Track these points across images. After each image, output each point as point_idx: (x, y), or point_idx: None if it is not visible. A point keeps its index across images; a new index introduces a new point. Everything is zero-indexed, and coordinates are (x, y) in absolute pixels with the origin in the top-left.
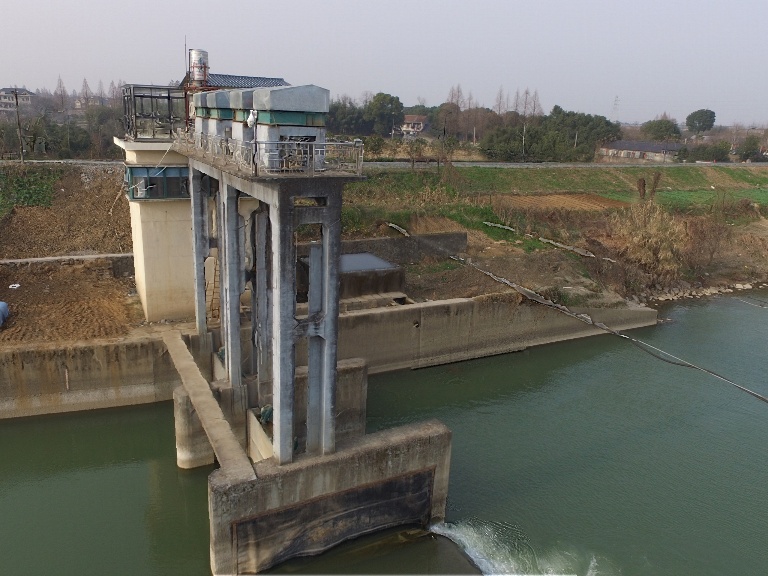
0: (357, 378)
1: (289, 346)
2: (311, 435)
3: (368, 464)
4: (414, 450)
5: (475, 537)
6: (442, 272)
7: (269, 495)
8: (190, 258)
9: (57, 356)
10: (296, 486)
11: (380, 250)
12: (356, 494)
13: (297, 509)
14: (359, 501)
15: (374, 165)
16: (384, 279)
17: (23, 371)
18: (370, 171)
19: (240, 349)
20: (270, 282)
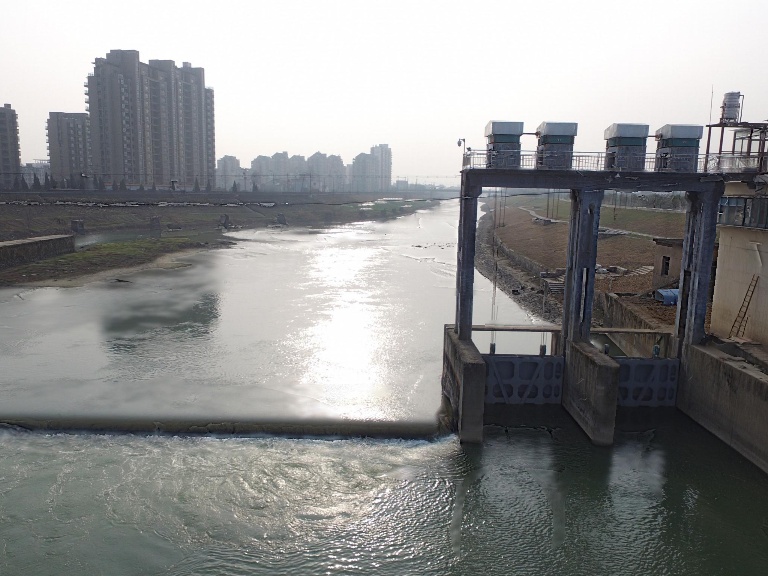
0: None
1: None
2: None
3: None
4: None
5: None
6: None
7: None
8: (738, 284)
9: None
10: None
11: None
12: None
13: None
14: None
15: None
16: None
17: None
18: None
19: (566, 308)
20: None
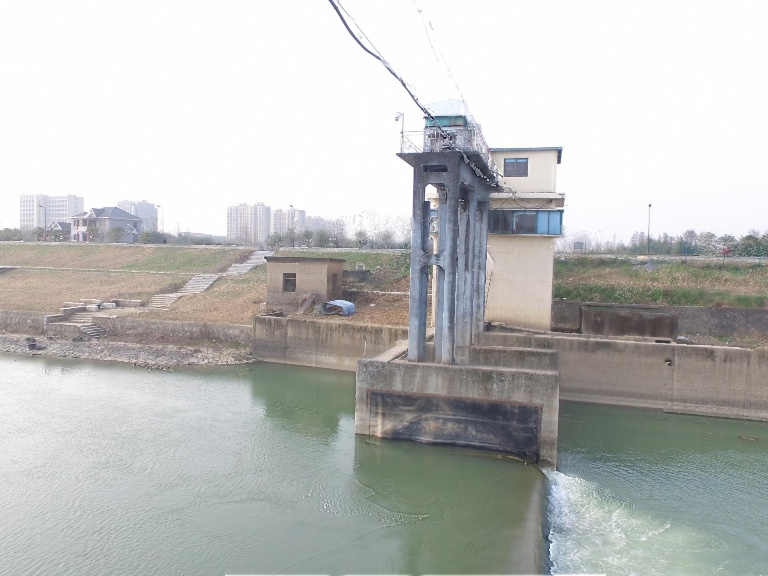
0: (543, 362)
1: (417, 269)
2: (438, 349)
3: (475, 380)
4: (519, 381)
5: (574, 484)
6: (759, 342)
7: (395, 378)
8: None
9: (362, 330)
10: (415, 378)
11: (692, 318)
12: (464, 404)
13: (415, 398)
14: (467, 411)
15: (750, 259)
16: (651, 323)
17: (343, 337)
18: (739, 263)
19: None
20: (468, 265)
